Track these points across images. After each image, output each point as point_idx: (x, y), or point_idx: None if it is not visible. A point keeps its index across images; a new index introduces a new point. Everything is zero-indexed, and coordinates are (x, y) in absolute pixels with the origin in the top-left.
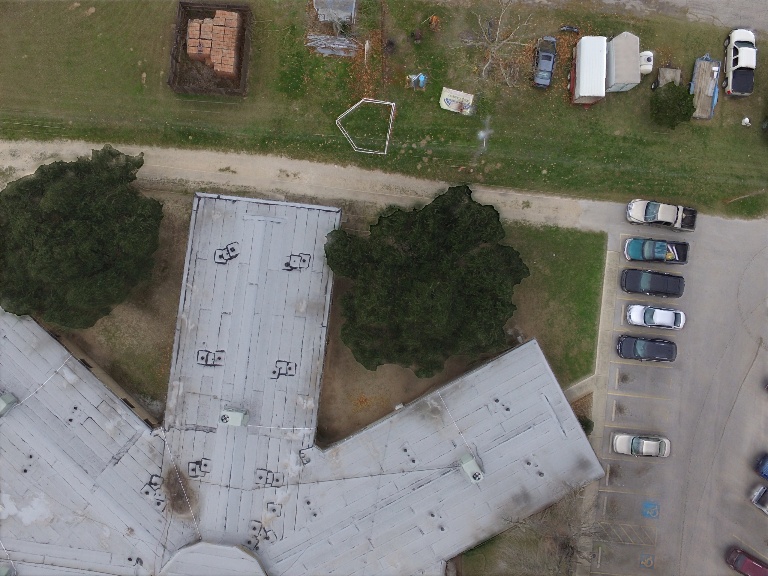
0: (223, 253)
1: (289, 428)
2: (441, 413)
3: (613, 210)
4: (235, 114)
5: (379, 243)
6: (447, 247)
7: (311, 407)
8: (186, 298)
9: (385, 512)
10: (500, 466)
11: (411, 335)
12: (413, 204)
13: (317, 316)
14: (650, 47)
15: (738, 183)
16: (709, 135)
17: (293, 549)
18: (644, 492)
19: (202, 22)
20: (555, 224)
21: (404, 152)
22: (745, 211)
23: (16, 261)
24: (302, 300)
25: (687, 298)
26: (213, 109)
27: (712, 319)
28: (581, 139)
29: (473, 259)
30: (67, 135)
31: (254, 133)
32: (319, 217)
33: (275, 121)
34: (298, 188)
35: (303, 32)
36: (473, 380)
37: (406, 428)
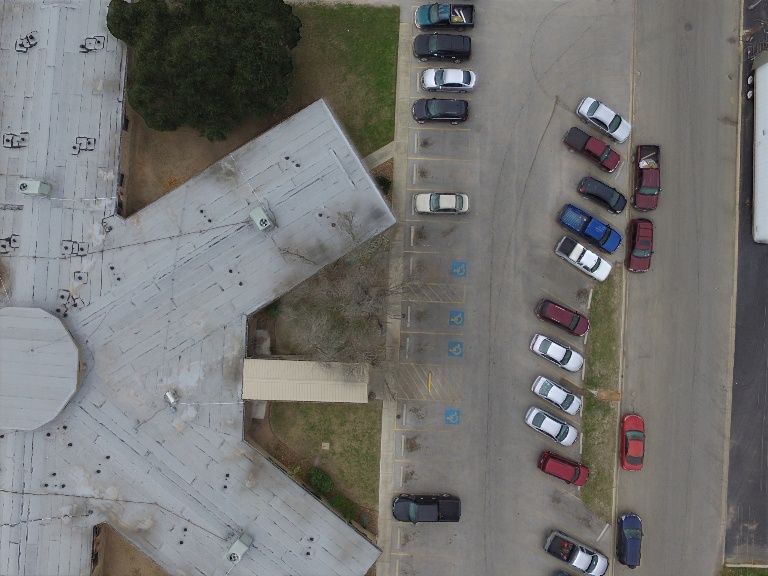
0: (23, 42)
1: (90, 199)
2: (234, 174)
3: None
4: None
5: None
6: None
7: (111, 178)
8: None
9: (184, 270)
10: (293, 219)
11: (183, 82)
12: None
13: (113, 92)
14: None
15: None
16: None
17: (98, 312)
18: (449, 251)
19: None
20: (348, 2)
21: None
22: None
23: None
24: (99, 79)
25: (481, 63)
26: None
27: (507, 81)
28: None
29: None
30: None
31: None
32: None
33: None
34: None
35: None
36: (264, 141)
37: (202, 191)
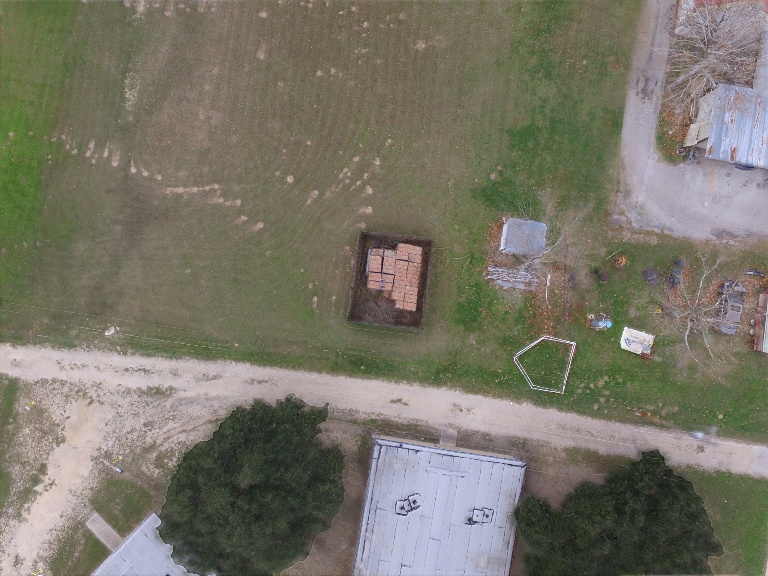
0: (405, 505)
1: None
2: None
3: None
4: (410, 345)
5: (588, 534)
6: (652, 536)
7: None
8: (365, 549)
9: None
10: None
11: None
12: (588, 445)
13: (498, 572)
14: None
15: None
16: None
17: None
18: None
19: (383, 253)
20: (728, 470)
21: (582, 392)
22: None
23: (206, 529)
24: (483, 555)
25: None
26: (387, 339)
27: None
28: (760, 386)
29: (681, 554)
30: (232, 357)
31: (428, 365)
32: (504, 471)
33: (451, 354)
34: (472, 424)
35: (483, 262)
36: None
37: None
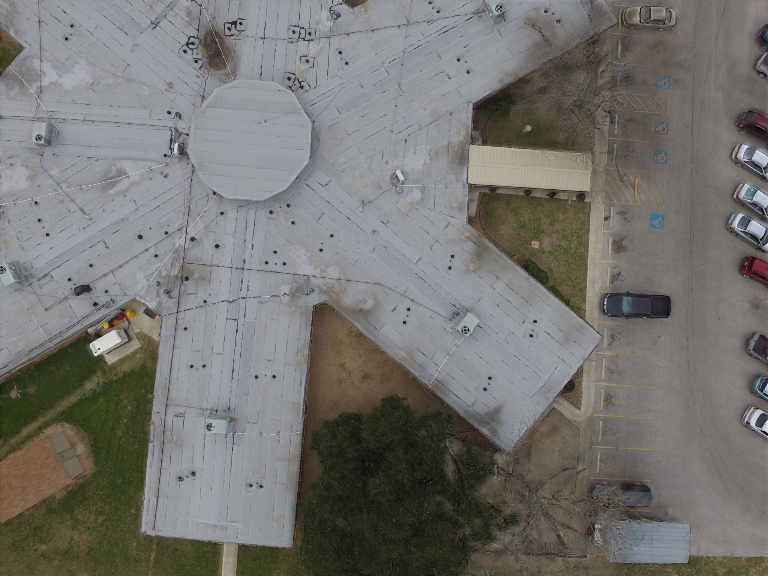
0: None
1: None
2: None
3: None
4: None
5: None
6: None
7: None
8: None
9: (413, 56)
10: (519, 14)
11: None
12: None
13: None
14: None
15: None
16: None
17: (327, 93)
18: (654, 65)
19: None
20: None
21: None
22: None
23: None
24: None
25: None
26: None
27: None
28: None
29: None
30: None
31: None
32: None
33: None
34: None
35: None
36: None
37: None
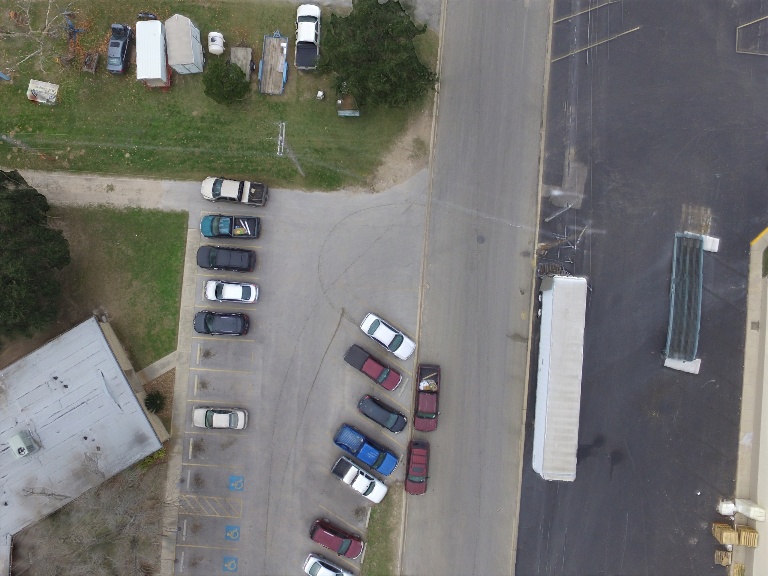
0: None
1: None
2: (5, 392)
3: (194, 189)
4: None
5: None
6: None
7: None
8: None
9: None
10: (59, 441)
11: None
12: None
13: None
14: (226, 28)
15: (316, 156)
16: (286, 110)
17: None
18: (228, 465)
19: None
20: (138, 205)
21: None
22: (324, 183)
23: None
24: None
25: (267, 272)
26: None
27: (293, 291)
28: (160, 121)
29: None
30: None
31: None
32: None
33: None
34: None
35: None
36: (35, 359)
37: None
